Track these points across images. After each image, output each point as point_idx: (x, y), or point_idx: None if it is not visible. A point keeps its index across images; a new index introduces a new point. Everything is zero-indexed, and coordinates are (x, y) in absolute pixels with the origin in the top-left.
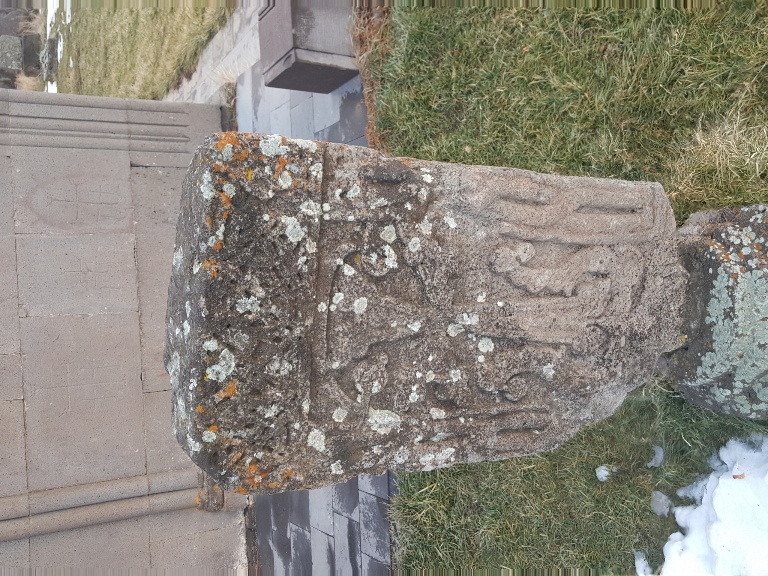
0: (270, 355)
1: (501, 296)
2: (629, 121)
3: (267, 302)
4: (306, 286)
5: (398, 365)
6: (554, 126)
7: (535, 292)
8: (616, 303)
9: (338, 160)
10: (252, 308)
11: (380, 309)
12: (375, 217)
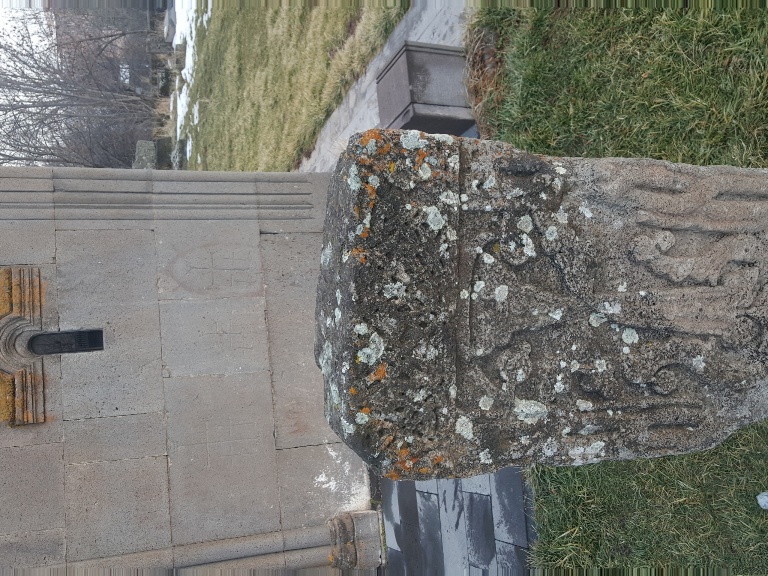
0: (417, 339)
1: (642, 286)
2: (762, 127)
3: (412, 288)
4: (448, 272)
5: (541, 355)
6: (681, 145)
7: (678, 281)
8: (766, 293)
9: (473, 154)
10: (398, 293)
11: (521, 297)
12: (511, 206)
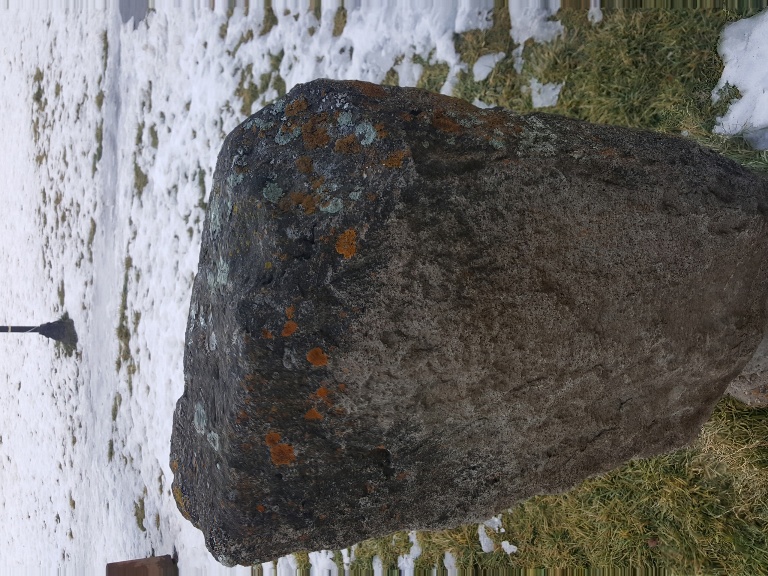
0: None
1: None
2: None
3: None
4: None
5: None
6: None
7: None
8: None
9: None
10: None
11: None
12: None
